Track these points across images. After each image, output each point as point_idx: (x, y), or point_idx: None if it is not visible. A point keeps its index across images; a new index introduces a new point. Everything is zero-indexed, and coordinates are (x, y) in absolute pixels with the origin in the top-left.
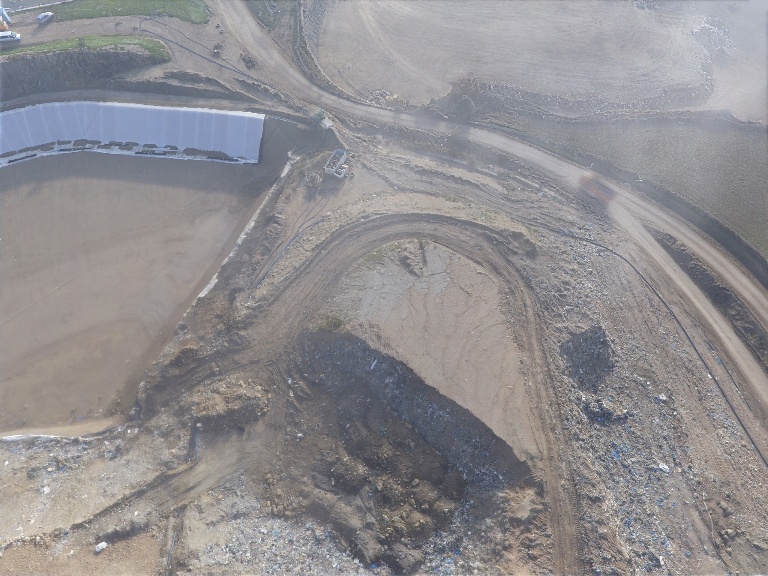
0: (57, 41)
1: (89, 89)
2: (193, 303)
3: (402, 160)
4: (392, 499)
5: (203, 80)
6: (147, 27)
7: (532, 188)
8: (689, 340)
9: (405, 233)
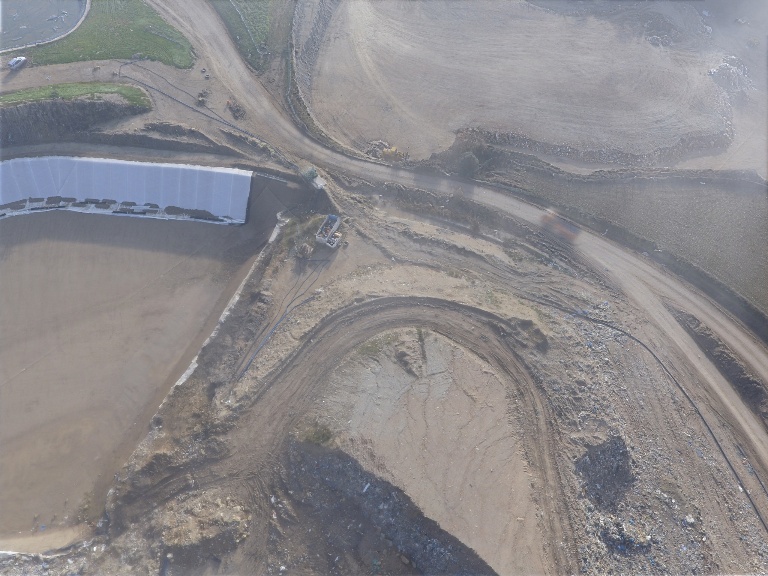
0: (29, 89)
1: (63, 142)
2: (170, 392)
3: (400, 226)
4: None
5: (186, 132)
6: (127, 72)
7: (541, 258)
8: (717, 444)
9: (403, 320)
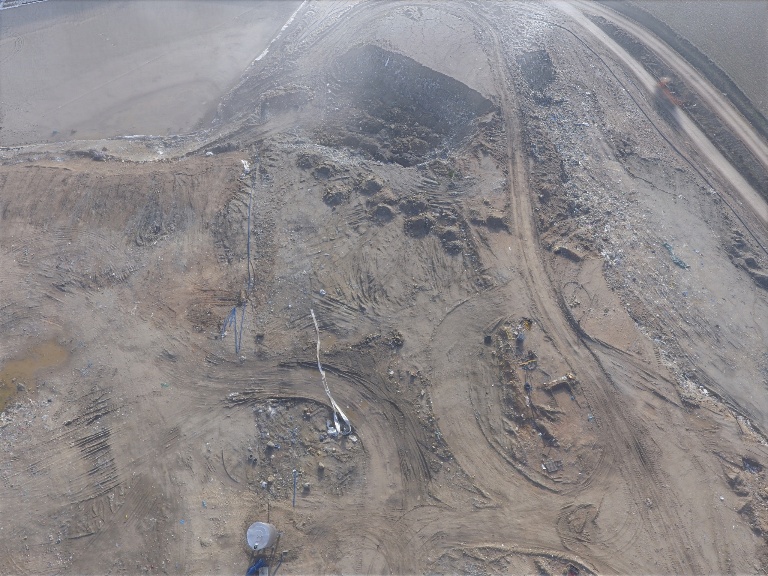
0: None
1: None
2: (252, 64)
3: None
4: (401, 131)
5: None
6: None
7: None
8: (611, 72)
9: (407, 5)
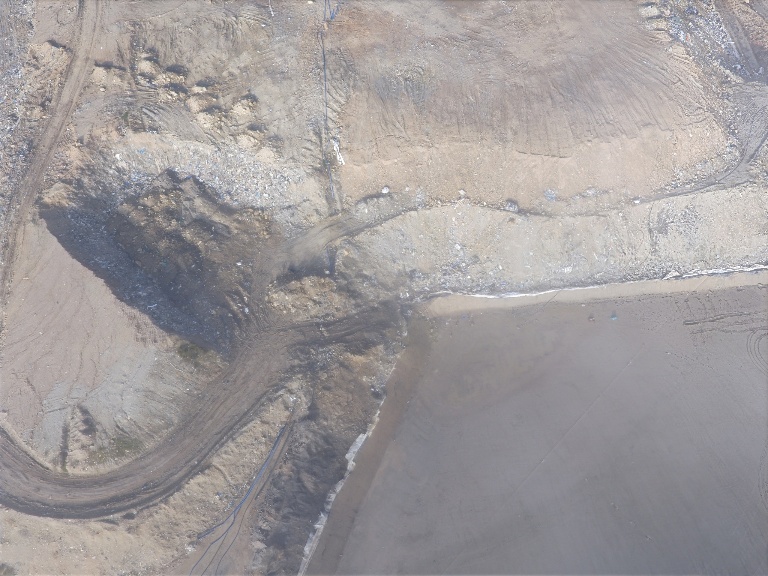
0: None
1: None
2: (371, 427)
3: None
4: (165, 212)
5: None
6: None
7: None
8: None
9: (82, 486)
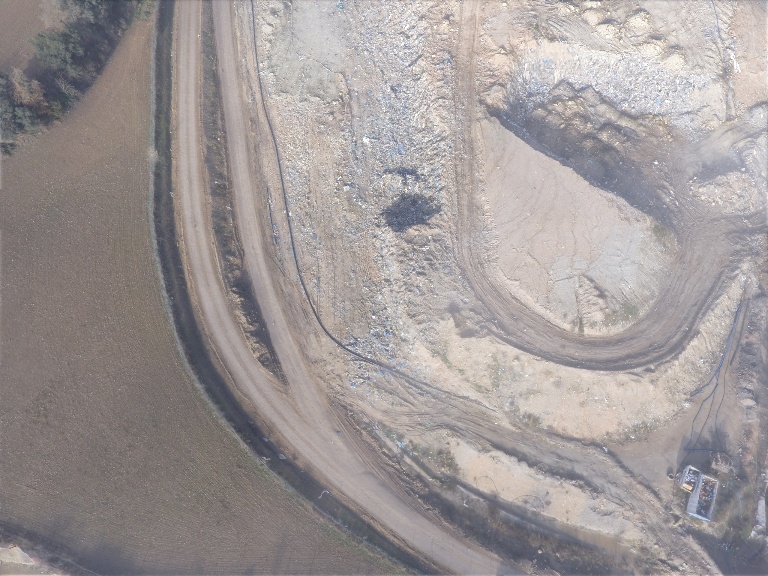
0: None
1: None
2: None
3: (602, 509)
4: (580, 116)
5: None
6: None
7: (413, 456)
8: (294, 246)
9: (598, 345)
